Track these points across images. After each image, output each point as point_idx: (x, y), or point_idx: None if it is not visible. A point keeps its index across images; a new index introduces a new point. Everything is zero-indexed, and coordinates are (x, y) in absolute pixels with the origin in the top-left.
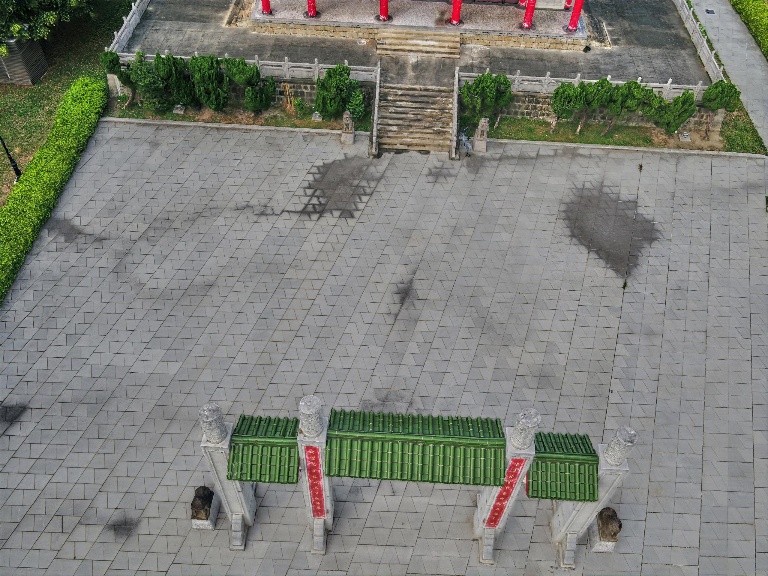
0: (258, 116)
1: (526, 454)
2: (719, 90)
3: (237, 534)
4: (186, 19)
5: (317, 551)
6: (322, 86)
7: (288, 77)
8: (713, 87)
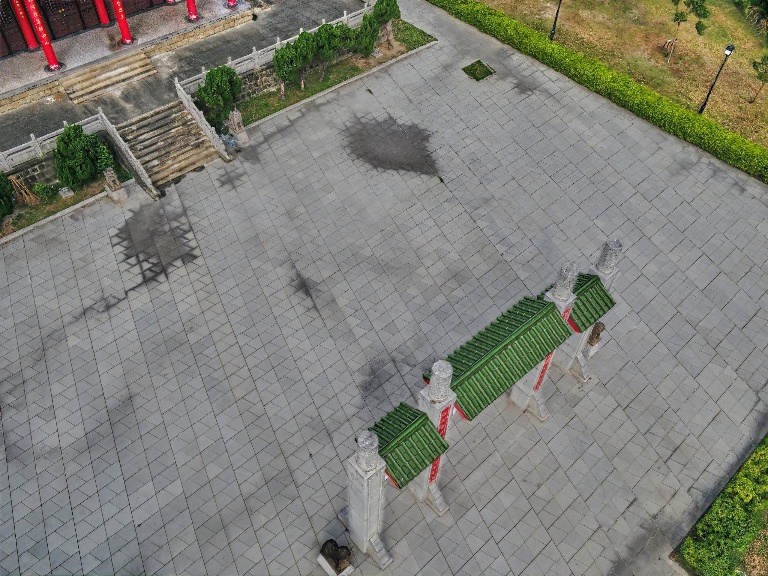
0: (0, 225)
1: (572, 301)
2: (385, 4)
3: (382, 552)
4: None
5: (443, 511)
6: (62, 157)
7: (8, 169)
8: (379, 4)
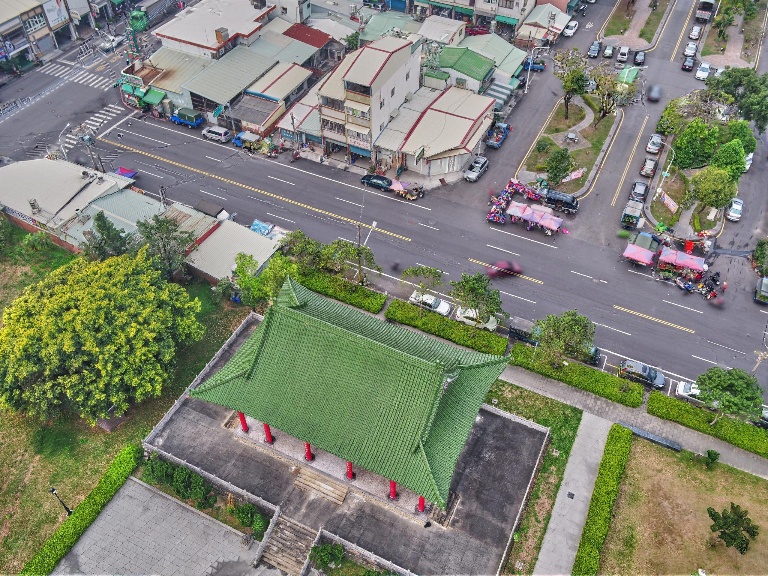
0: None
1: None
2: None
3: None
4: (205, 412)
5: None
6: (239, 512)
7: (231, 489)
8: None
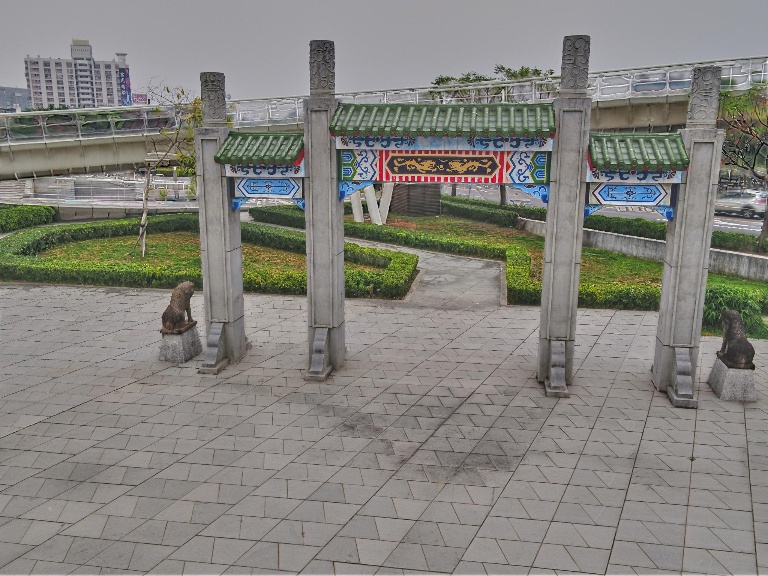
0: None
1: None
2: None
3: None
4: None
5: None
6: None
7: None
8: None
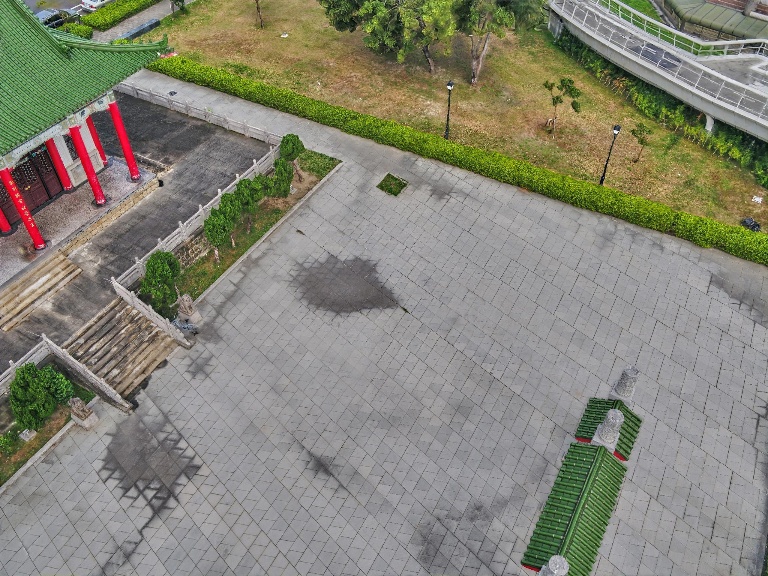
0: None
1: None
2: (291, 144)
3: None
4: None
5: None
6: (20, 403)
7: None
8: (285, 145)
